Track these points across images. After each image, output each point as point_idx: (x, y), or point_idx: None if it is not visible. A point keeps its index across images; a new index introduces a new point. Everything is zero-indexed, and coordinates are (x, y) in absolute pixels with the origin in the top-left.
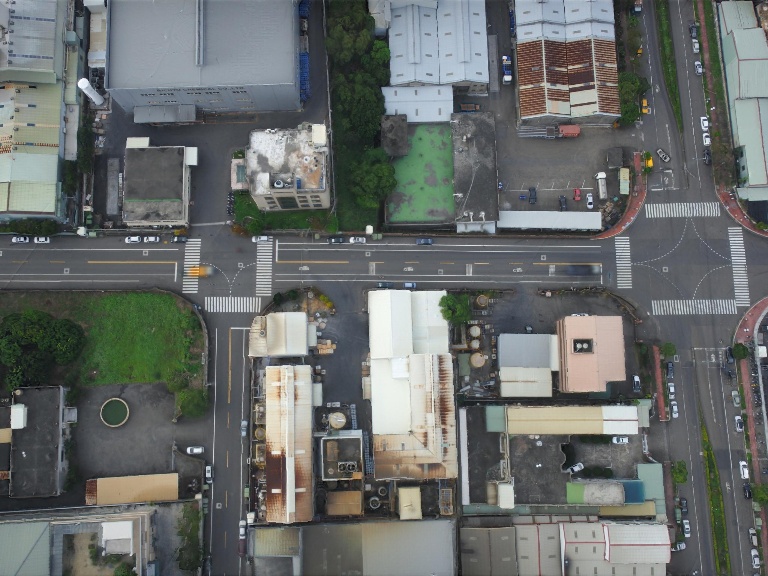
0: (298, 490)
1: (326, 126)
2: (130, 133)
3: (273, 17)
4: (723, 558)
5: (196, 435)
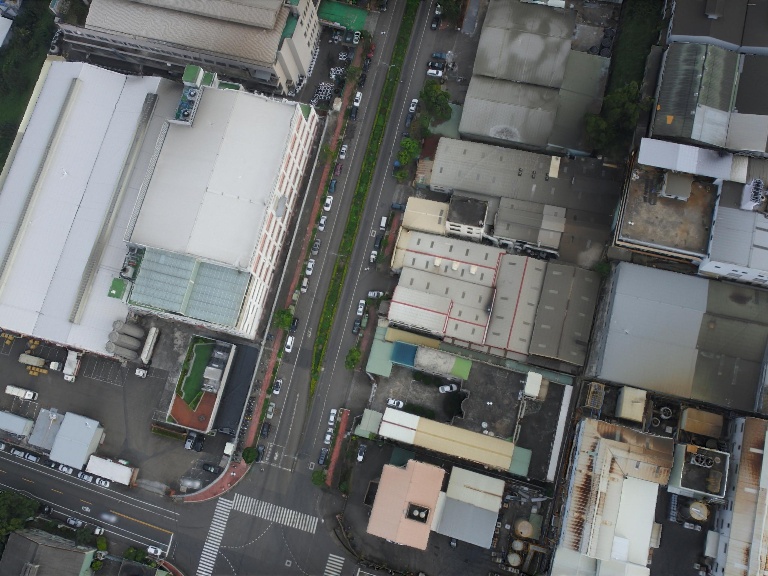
0: (759, 452)
1: None
2: None
3: None
4: (338, 275)
5: None
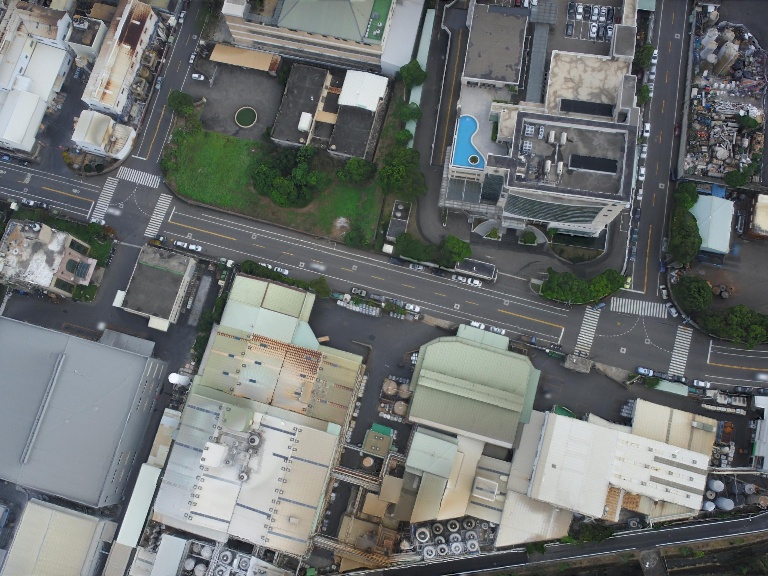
0: None
1: (10, 302)
2: (171, 344)
3: (1, 401)
4: None
5: (195, 88)
